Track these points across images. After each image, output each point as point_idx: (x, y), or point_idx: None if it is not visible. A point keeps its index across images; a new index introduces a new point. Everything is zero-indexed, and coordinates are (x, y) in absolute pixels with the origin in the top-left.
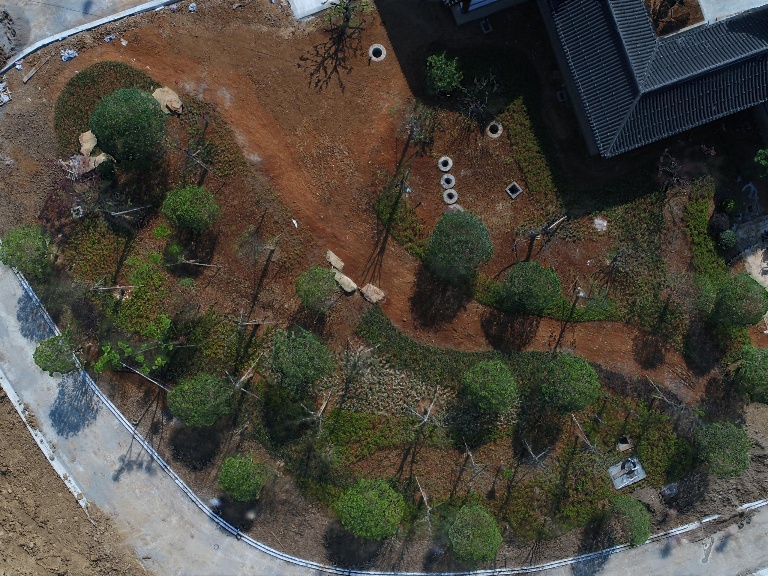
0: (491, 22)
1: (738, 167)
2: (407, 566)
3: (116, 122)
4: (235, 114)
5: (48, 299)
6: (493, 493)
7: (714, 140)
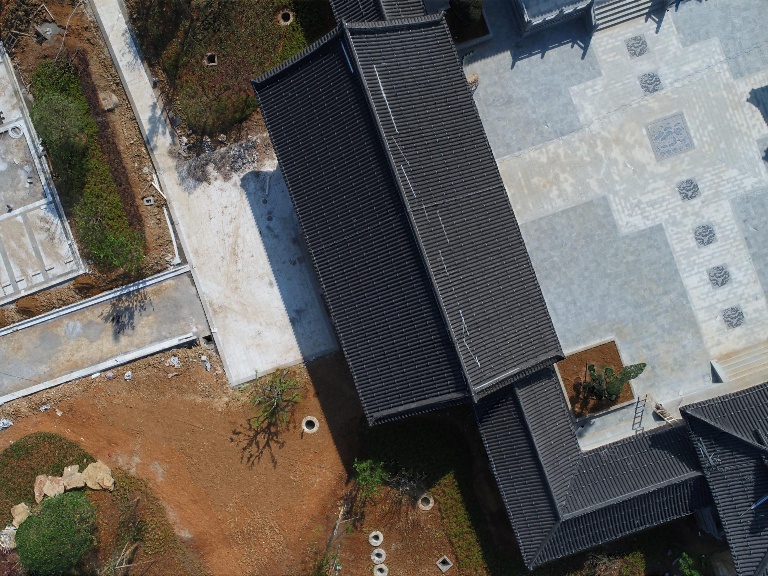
0: None
1: (668, 541)
2: None
3: (36, 557)
4: (167, 490)
5: None
6: None
7: None
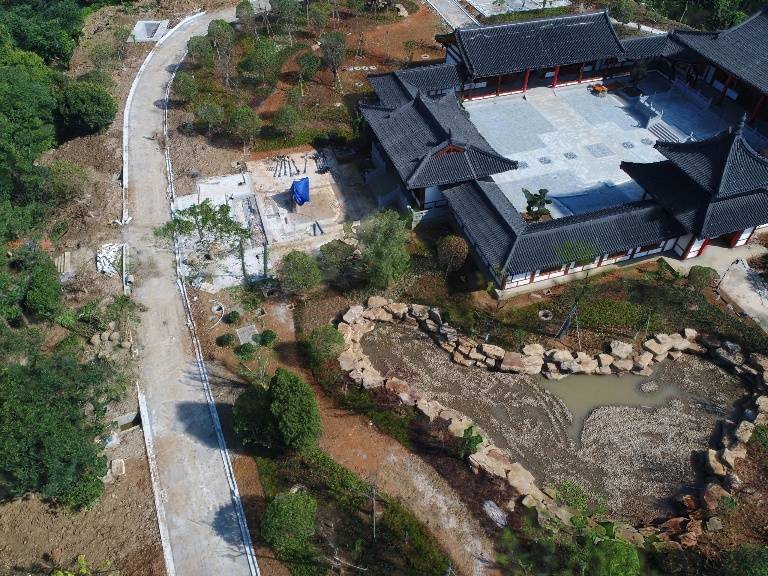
0: None
1: None
2: None
3: None
4: None
5: None
6: None
7: None
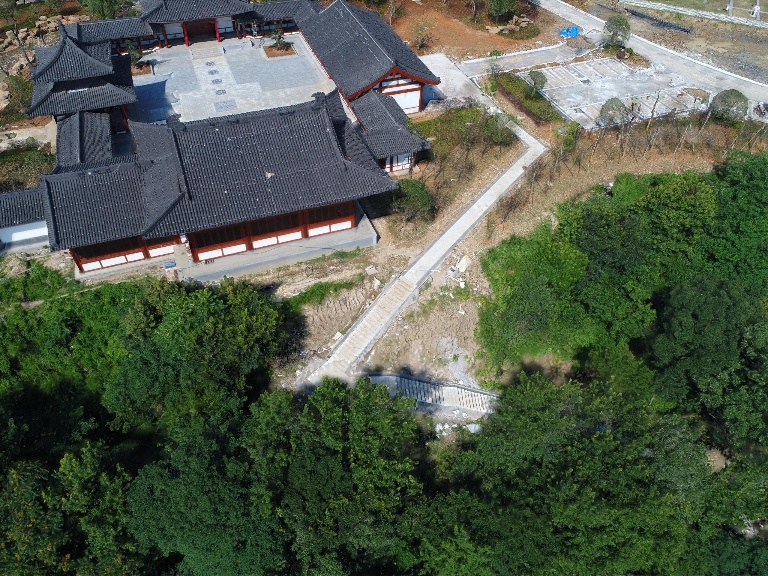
0: None
1: None
2: None
3: None
4: None
5: (529, 2)
6: None
7: None
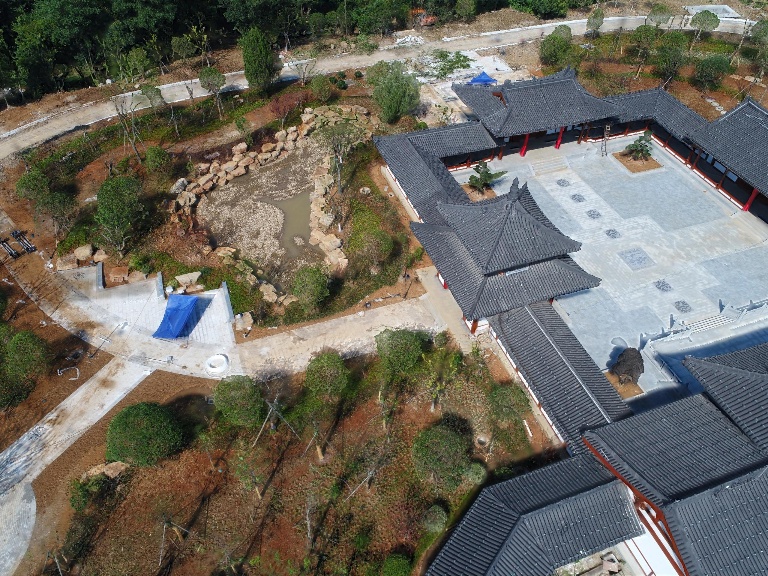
0: None
1: None
2: None
3: None
4: None
5: None
6: None
7: None
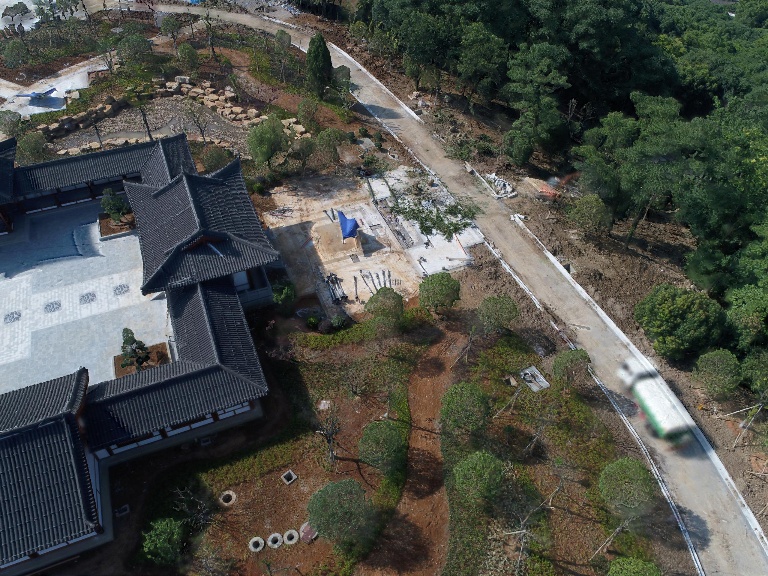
0: (119, 507)
1: (283, 320)
2: (689, 568)
3: None
4: None
5: None
6: (583, 481)
7: (261, 334)
